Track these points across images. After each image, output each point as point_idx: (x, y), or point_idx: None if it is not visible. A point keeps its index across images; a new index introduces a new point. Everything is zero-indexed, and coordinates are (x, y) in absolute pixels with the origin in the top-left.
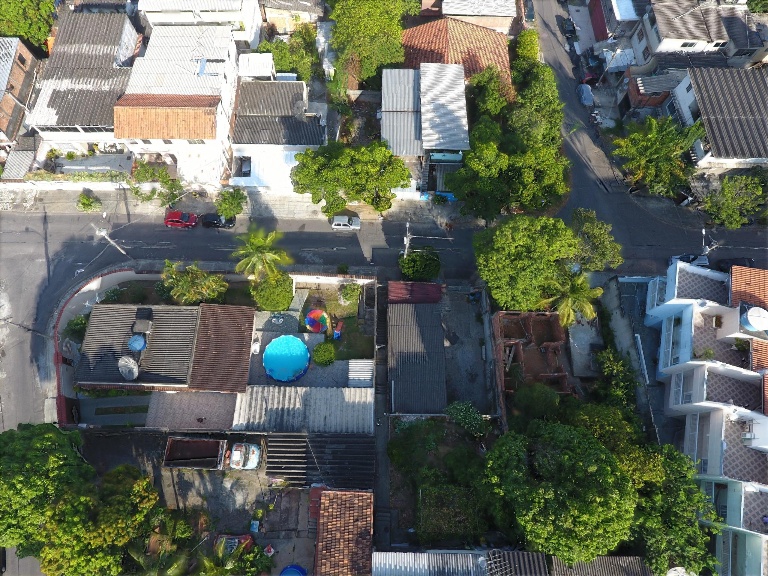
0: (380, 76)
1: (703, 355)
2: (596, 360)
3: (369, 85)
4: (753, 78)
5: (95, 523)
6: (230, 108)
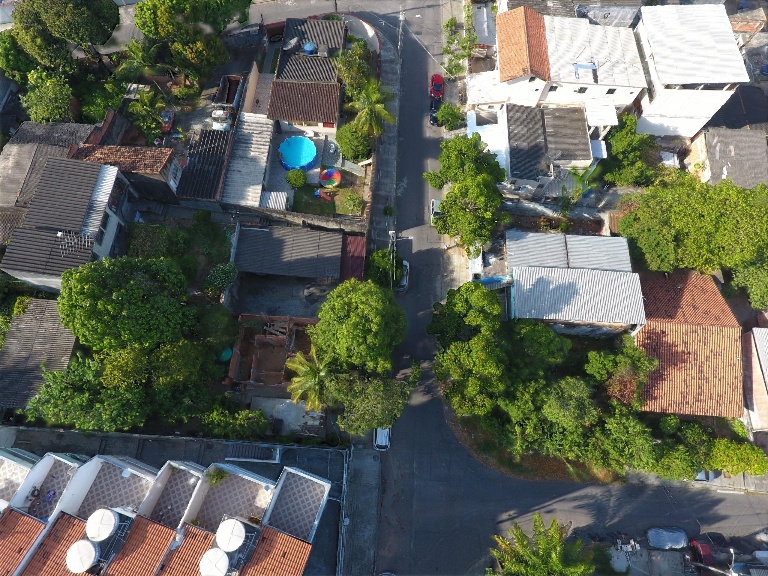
0: None
1: (214, 474)
2: None
3: None
4: None
5: None
6: (555, 107)
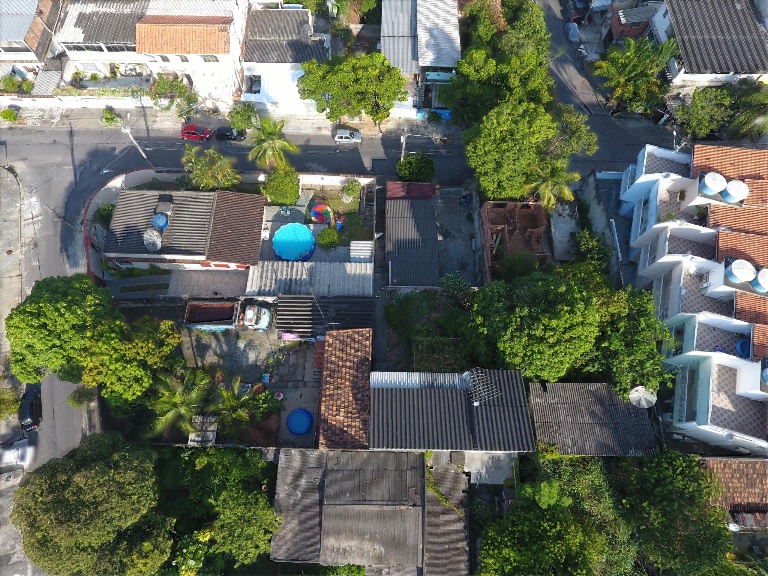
0: (380, 9)
1: (666, 218)
2: (575, 244)
3: (370, 20)
4: (724, 4)
5: (129, 341)
6: (241, 35)
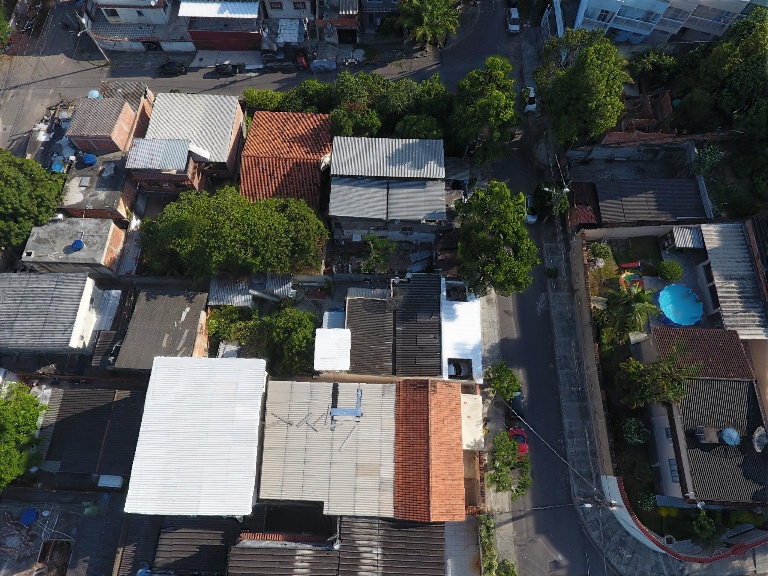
0: None
1: None
2: None
3: None
4: None
5: None
6: None
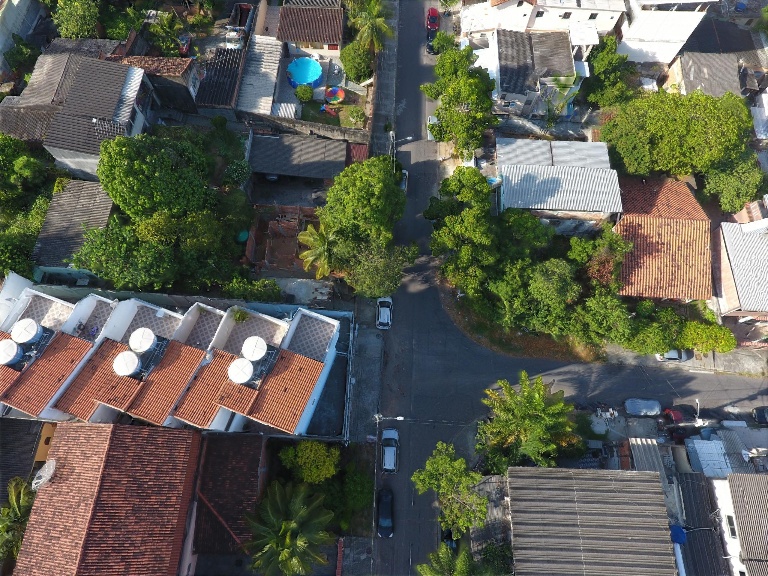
0: None
1: None
2: None
3: None
4: None
5: None
6: None
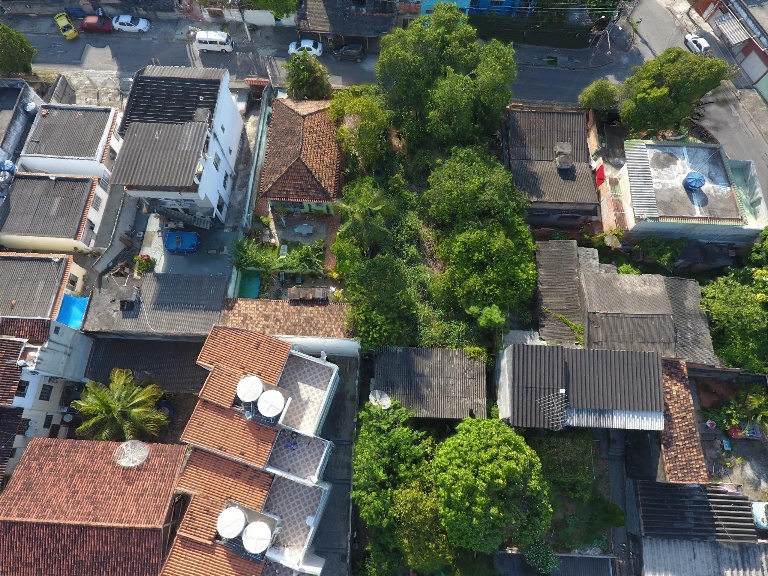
0: None
1: None
2: None
3: None
4: None
5: None
6: None
